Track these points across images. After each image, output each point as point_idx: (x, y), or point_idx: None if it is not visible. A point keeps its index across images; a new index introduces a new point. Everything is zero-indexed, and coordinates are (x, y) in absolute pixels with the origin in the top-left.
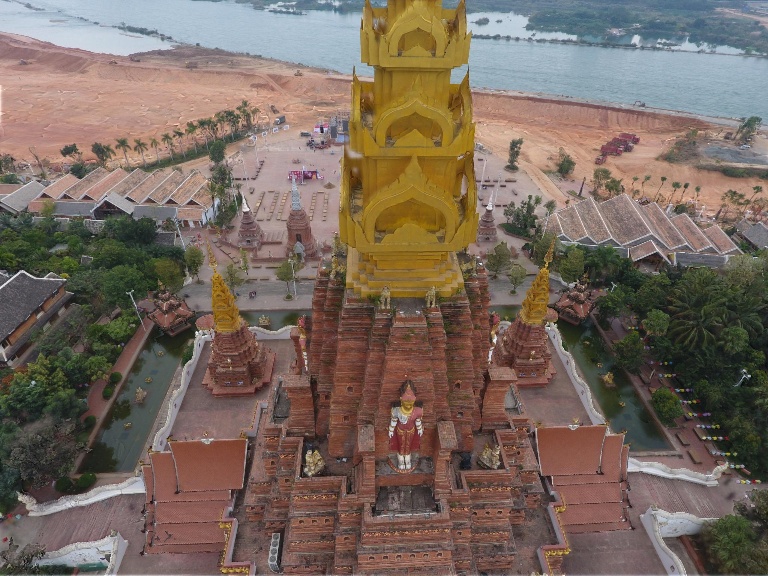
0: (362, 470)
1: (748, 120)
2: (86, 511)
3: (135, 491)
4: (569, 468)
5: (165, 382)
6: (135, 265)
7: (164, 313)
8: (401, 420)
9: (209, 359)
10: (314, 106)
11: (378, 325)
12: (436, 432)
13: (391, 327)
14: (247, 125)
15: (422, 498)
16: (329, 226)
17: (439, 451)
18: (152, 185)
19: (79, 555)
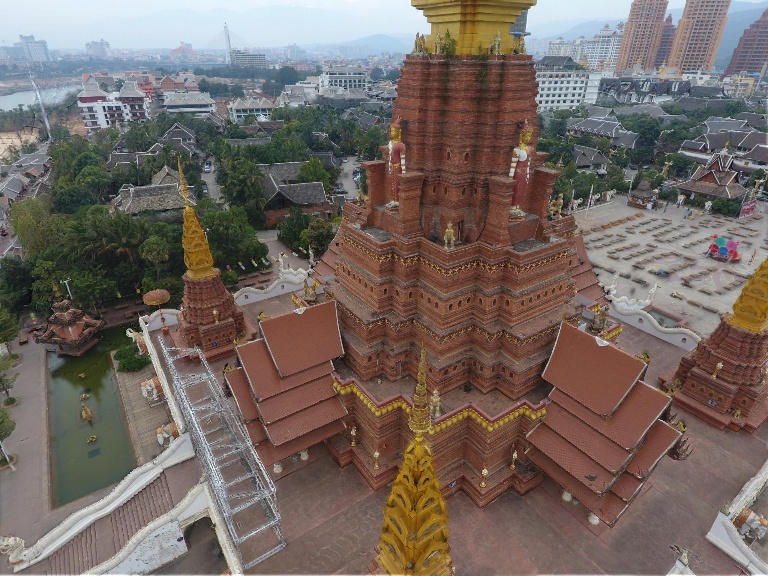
0: None
1: None
2: None
3: None
4: None
5: None
6: None
7: None
8: None
9: None
10: None
11: None
12: None
13: None
14: None
15: None
16: None
17: None
18: None
19: None
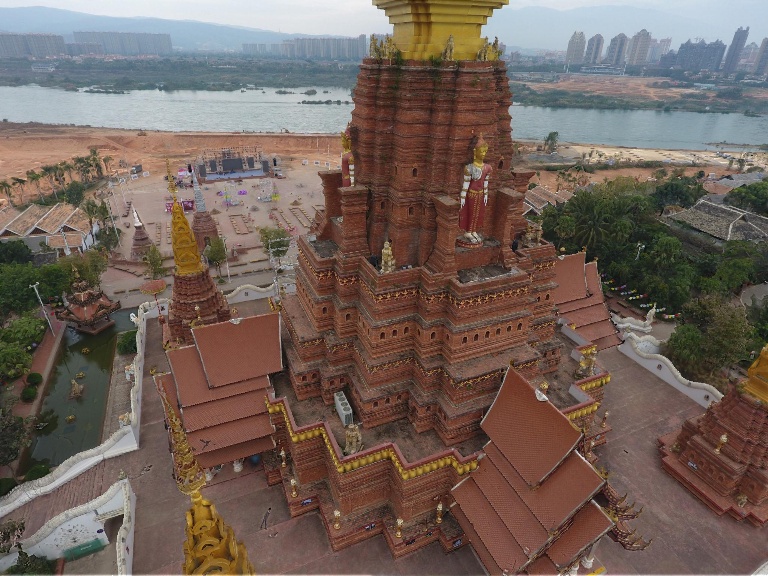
0: (437, 256)
1: (550, 135)
2: (54, 496)
3: (122, 450)
4: (566, 296)
5: (103, 373)
6: (30, 263)
7: (83, 304)
8: (476, 174)
9: (169, 317)
10: (169, 158)
11: (446, 79)
12: (498, 198)
13: (457, 79)
14: (98, 176)
15: (496, 270)
16: (229, 241)
17: (509, 206)
18: (5, 221)
19: (67, 532)
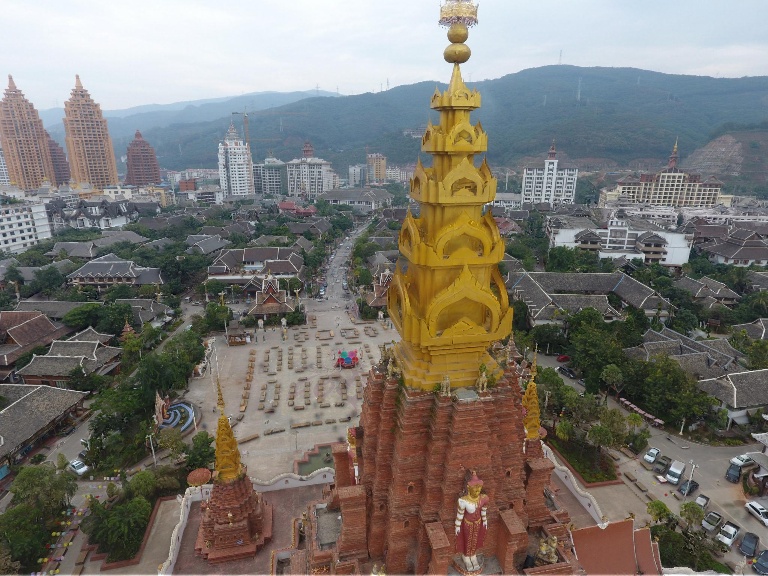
0: None
1: None
2: None
3: None
4: None
5: None
6: None
7: None
8: None
9: None
10: None
11: None
12: None
13: None
14: None
15: None
16: None
17: None
18: None
19: None
